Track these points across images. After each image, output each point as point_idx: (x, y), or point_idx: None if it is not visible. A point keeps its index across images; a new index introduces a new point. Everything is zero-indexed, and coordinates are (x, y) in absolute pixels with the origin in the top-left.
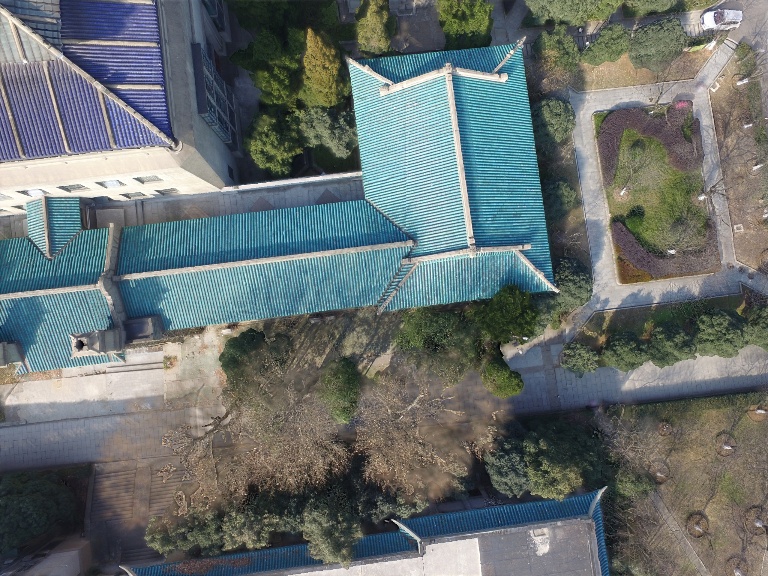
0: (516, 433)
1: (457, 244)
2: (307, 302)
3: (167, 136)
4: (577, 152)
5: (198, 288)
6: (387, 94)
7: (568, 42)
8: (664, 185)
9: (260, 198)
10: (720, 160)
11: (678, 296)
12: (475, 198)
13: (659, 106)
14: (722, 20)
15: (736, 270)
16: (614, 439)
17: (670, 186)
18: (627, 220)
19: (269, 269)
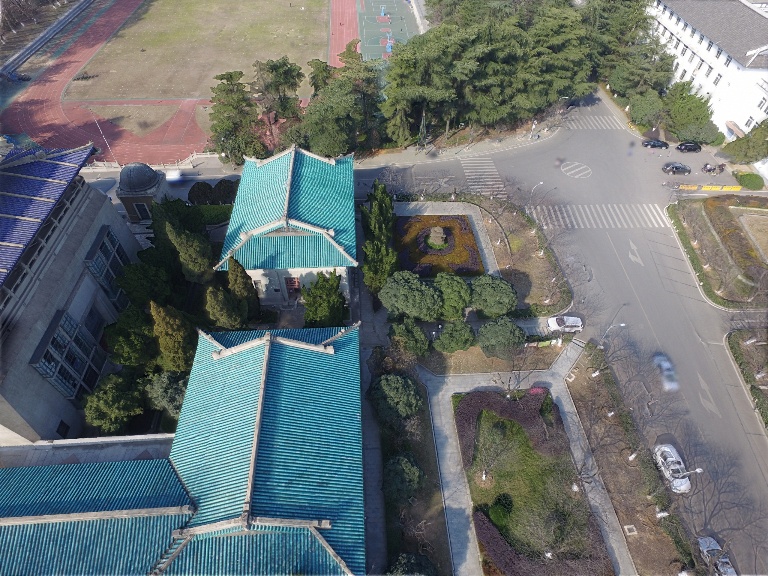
0: None
1: (235, 512)
2: None
3: None
4: (436, 431)
5: None
6: (219, 358)
7: (416, 332)
8: (531, 471)
9: (72, 455)
10: (590, 448)
11: None
12: (269, 459)
13: (517, 391)
14: (564, 324)
15: None
16: None
17: (538, 473)
18: (490, 510)
19: (14, 533)
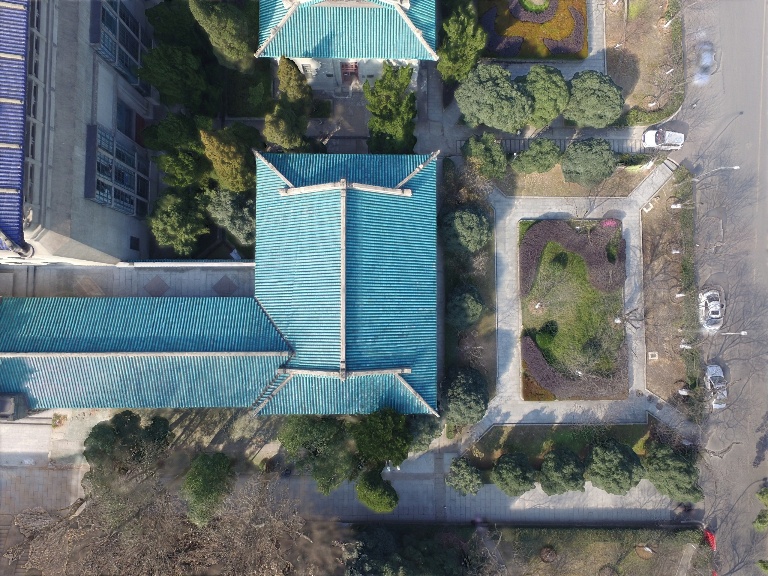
0: (385, 550)
1: (331, 364)
2: (179, 397)
3: (14, 244)
4: (498, 258)
5: (67, 372)
6: (287, 195)
7: (495, 150)
8: (582, 303)
9: (156, 276)
10: (643, 283)
11: (582, 418)
12: (356, 318)
13: (588, 221)
14: (663, 141)
15: (645, 398)
16: (479, 573)
17: (588, 305)
18: (537, 336)
19: (141, 362)
